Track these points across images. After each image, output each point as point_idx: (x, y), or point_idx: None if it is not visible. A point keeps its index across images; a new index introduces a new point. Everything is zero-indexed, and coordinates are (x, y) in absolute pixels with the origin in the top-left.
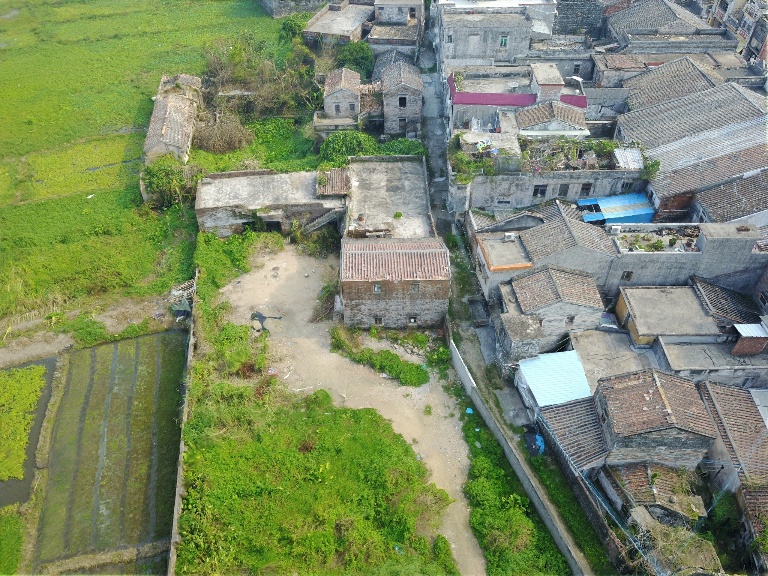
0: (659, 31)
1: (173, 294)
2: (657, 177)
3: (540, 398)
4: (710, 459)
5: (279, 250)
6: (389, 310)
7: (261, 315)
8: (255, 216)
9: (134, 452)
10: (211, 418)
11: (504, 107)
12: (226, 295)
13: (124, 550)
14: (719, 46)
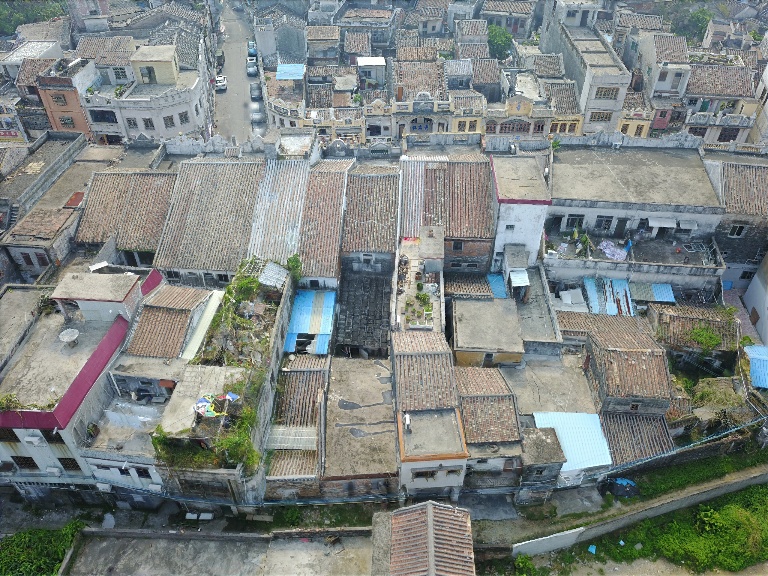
0: (2, 173)
1: None
2: (300, 268)
3: (602, 460)
4: None
5: None
6: None
7: None
8: None
9: None
10: None
11: (109, 363)
12: None
13: None
14: (76, 148)
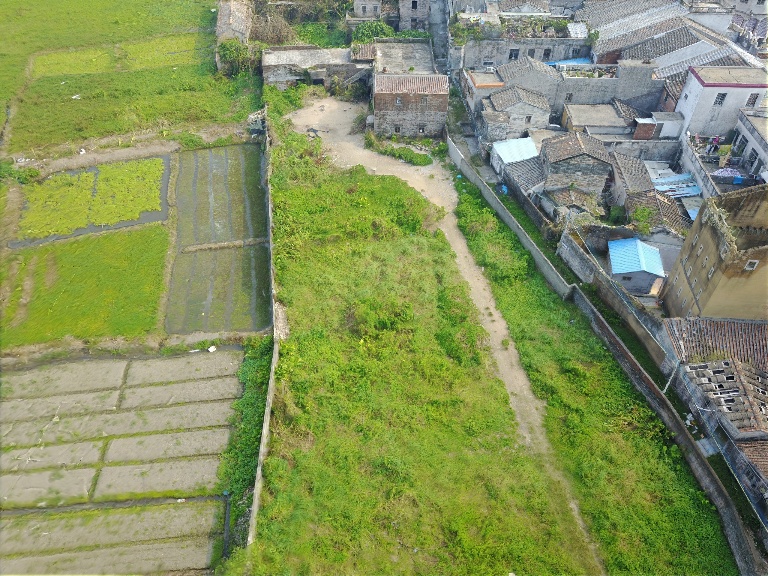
0: None
1: (250, 117)
2: (597, 44)
3: (505, 159)
4: (613, 197)
5: (324, 97)
6: (406, 120)
7: (314, 129)
8: (306, 74)
9: (233, 200)
10: (287, 173)
11: None
12: None
13: (235, 241)
14: None
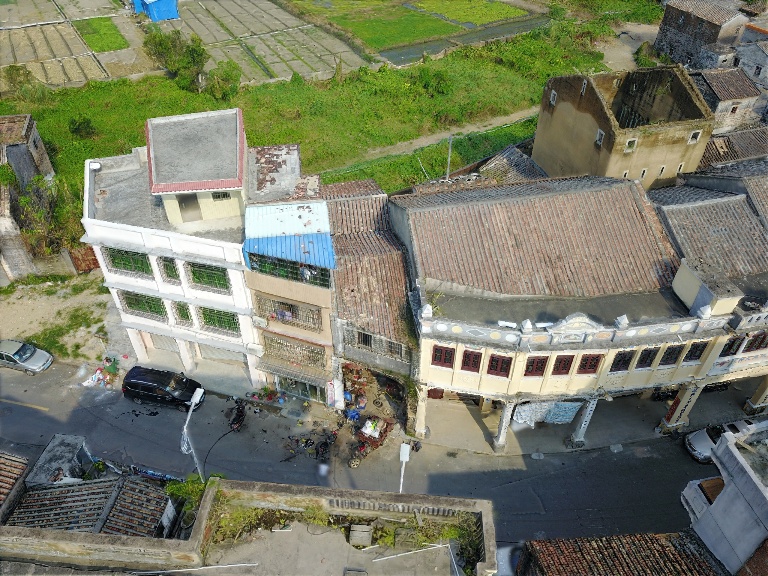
0: None
1: None
2: None
3: None
4: None
5: None
6: (680, 43)
7: (627, 33)
8: None
9: None
10: (549, 31)
11: None
12: (626, 24)
13: None
14: None
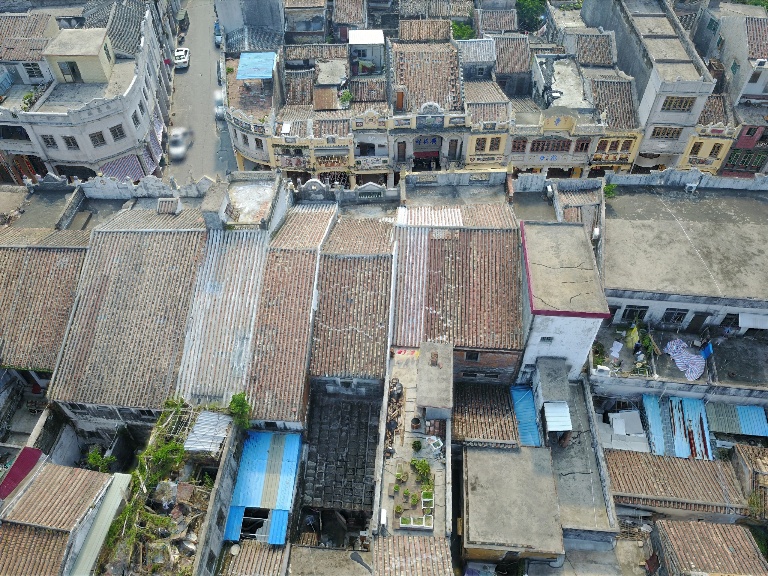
0: None
1: None
2: (250, 405)
3: None
4: None
5: None
6: None
7: None
8: None
9: None
10: None
11: None
12: None
13: None
14: None
